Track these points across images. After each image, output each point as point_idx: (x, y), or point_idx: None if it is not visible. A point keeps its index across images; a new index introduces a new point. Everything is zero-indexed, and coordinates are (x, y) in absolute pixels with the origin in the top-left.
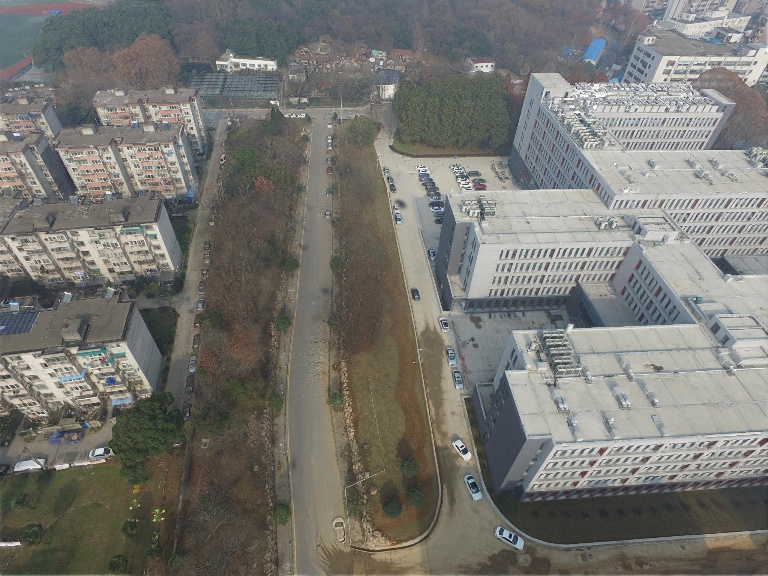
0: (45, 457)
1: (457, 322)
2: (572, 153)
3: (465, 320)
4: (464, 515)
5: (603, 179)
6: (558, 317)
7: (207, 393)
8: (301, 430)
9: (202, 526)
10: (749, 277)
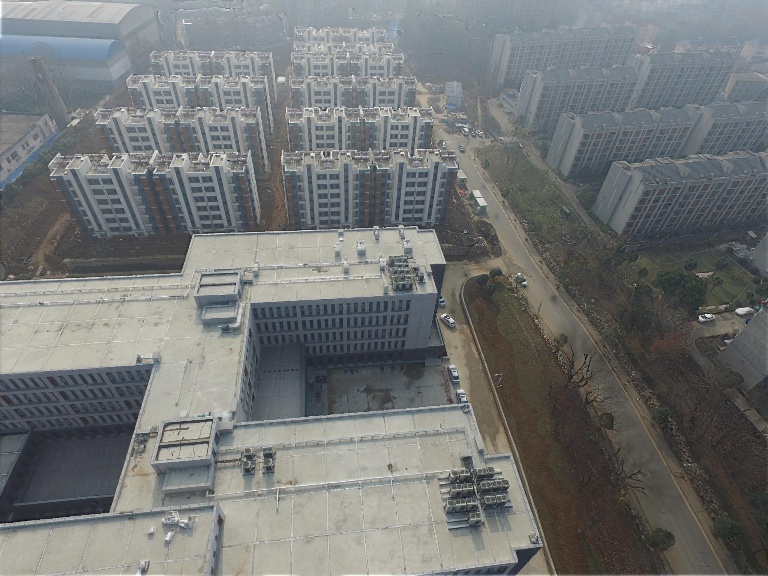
0: (742, 317)
1: None
2: None
3: None
4: (445, 289)
5: (209, 568)
6: None
7: (673, 354)
8: (577, 332)
9: (604, 282)
10: None
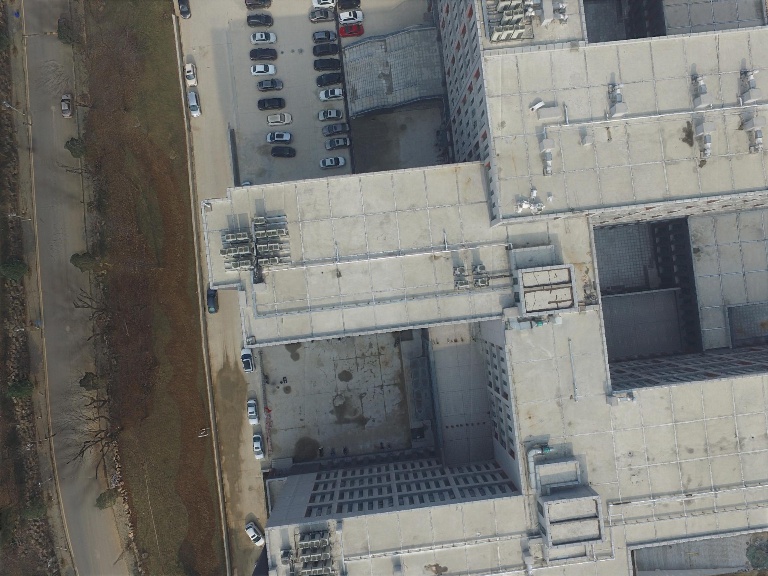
0: None
1: (267, 351)
2: (474, 35)
3: (278, 347)
4: None
5: (493, 168)
6: (407, 333)
7: None
8: (79, 522)
9: None
10: (648, 390)
